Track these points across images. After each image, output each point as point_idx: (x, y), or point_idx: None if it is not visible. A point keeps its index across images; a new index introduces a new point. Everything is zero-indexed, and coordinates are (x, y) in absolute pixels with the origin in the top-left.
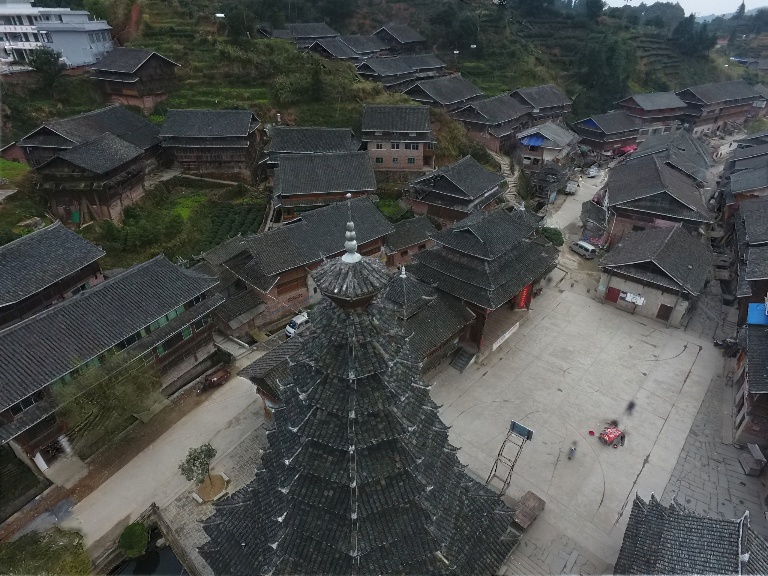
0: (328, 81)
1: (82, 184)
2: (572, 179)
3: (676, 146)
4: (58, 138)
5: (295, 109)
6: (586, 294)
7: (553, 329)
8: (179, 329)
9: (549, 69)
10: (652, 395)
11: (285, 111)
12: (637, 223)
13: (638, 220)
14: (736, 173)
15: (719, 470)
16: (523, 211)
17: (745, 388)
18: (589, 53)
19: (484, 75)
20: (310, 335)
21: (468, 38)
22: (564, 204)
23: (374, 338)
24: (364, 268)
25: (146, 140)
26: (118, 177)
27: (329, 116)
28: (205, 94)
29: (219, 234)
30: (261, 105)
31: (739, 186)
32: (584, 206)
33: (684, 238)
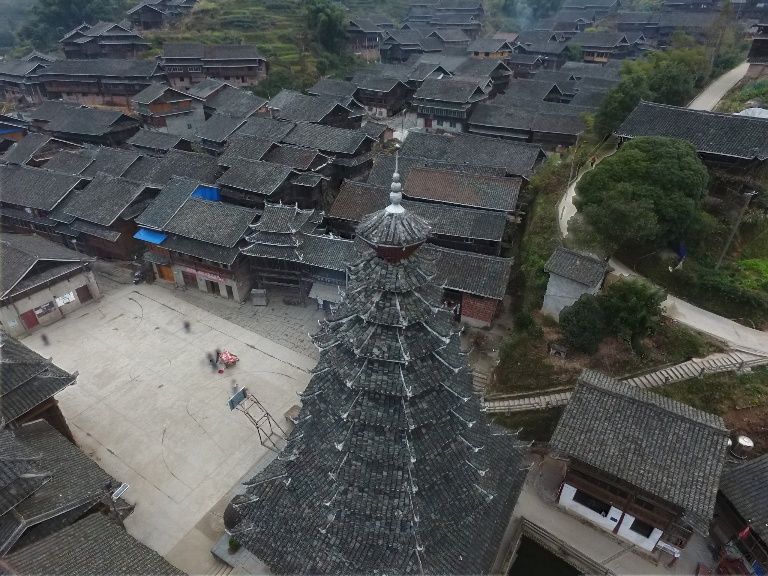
0: None
1: None
2: None
3: None
4: None
5: None
6: None
7: None
8: None
9: None
10: (184, 330)
11: None
12: None
13: None
14: None
15: (262, 316)
16: None
17: (204, 277)
18: None
19: None
20: None
21: None
22: None
23: None
24: None
25: None
26: None
27: None
28: None
29: None
30: None
31: None
32: None
33: (3, 236)
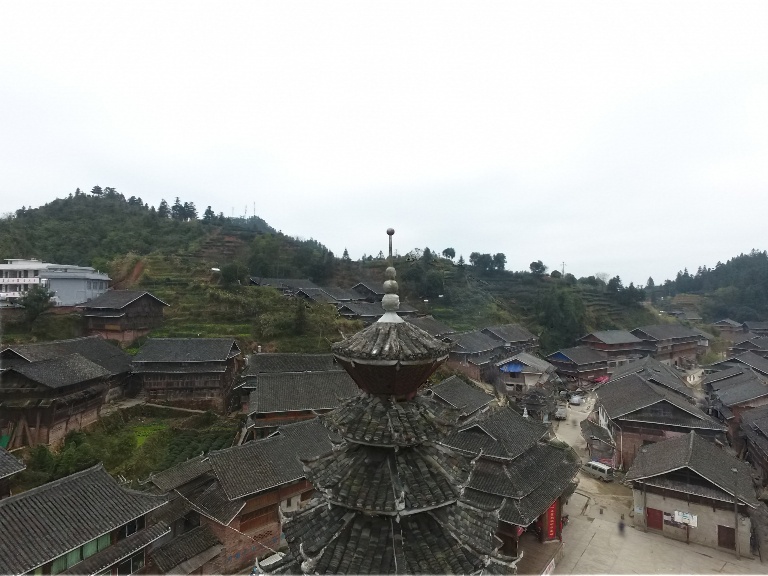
0: (311, 317)
1: (27, 401)
2: (559, 404)
3: (651, 368)
4: (19, 361)
5: (277, 341)
6: (621, 521)
7: (599, 567)
8: (94, 573)
9: (511, 313)
10: None
11: (266, 343)
12: (646, 437)
13: (646, 434)
14: (720, 389)
15: None
16: (527, 418)
17: None
18: (542, 301)
19: (454, 318)
20: (321, 459)
21: (435, 289)
22: (558, 429)
23: (433, 436)
24: (411, 330)
25: (116, 367)
26: (73, 395)
27: (310, 347)
28: (188, 329)
29: (176, 462)
30: (243, 338)
31: (730, 399)
32: (583, 425)
33: (707, 446)
